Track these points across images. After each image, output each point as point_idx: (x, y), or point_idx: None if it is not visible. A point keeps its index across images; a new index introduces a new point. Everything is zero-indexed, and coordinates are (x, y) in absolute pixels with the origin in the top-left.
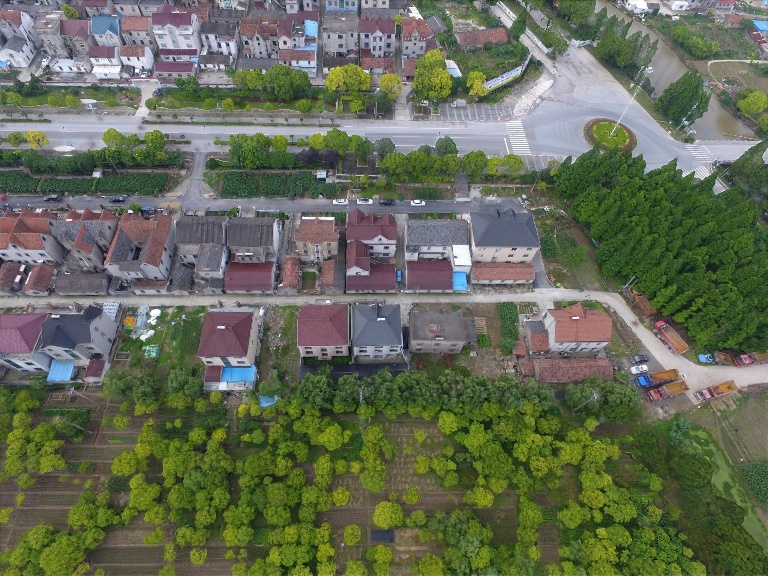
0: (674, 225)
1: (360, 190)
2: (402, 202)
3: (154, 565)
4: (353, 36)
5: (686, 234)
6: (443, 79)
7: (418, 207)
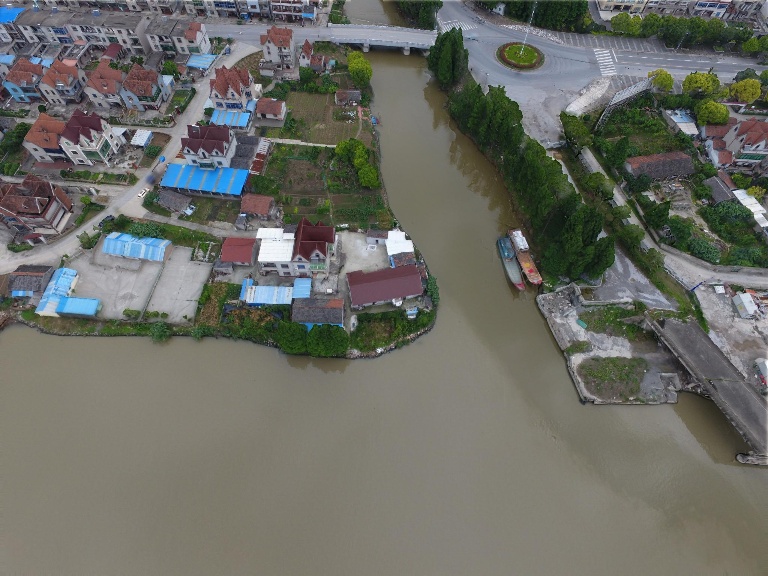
0: None
1: None
2: None
3: None
4: None
5: None
6: (701, 74)
7: None
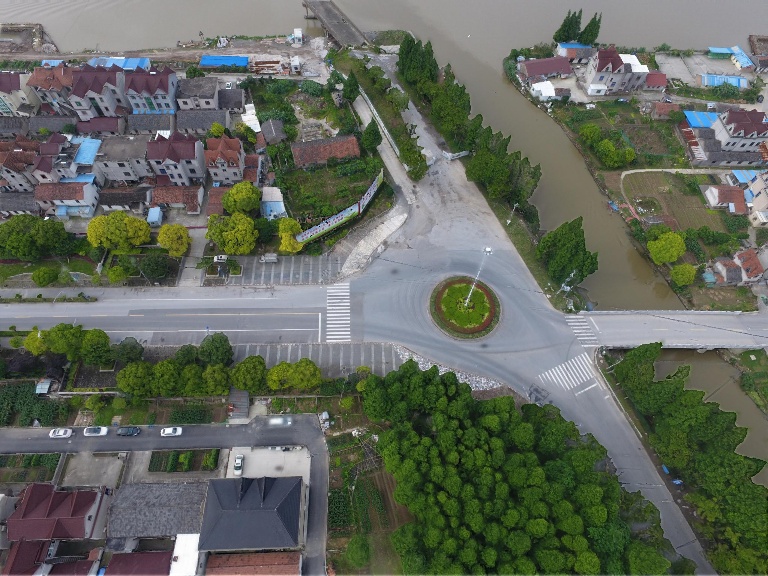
0: (496, 514)
1: (93, 412)
2: (151, 429)
3: None
4: (140, 163)
5: (512, 531)
6: (238, 233)
7: (171, 438)
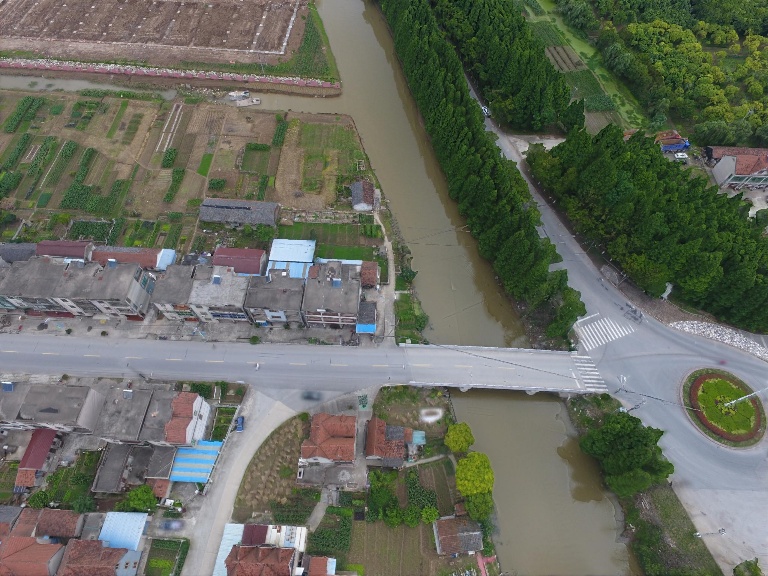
0: None
1: None
2: None
3: None
4: None
5: None
6: None
7: None
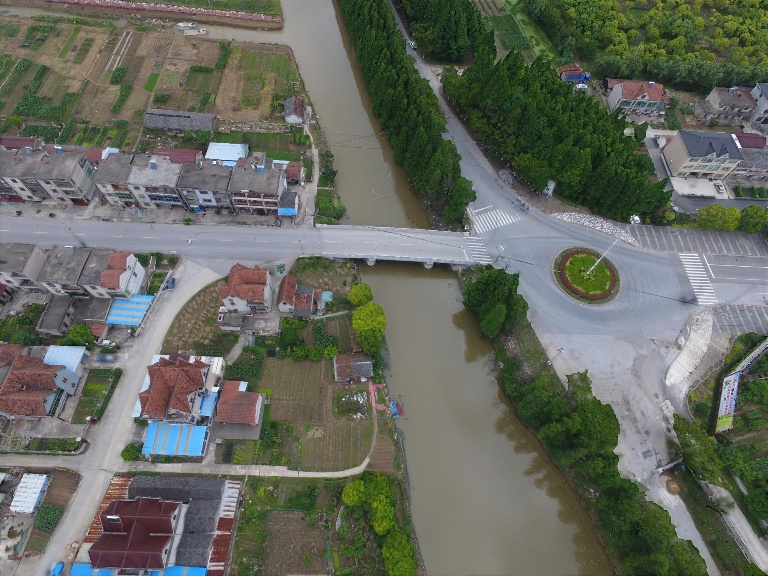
0: None
1: None
2: None
3: None
4: None
5: None
6: None
7: None
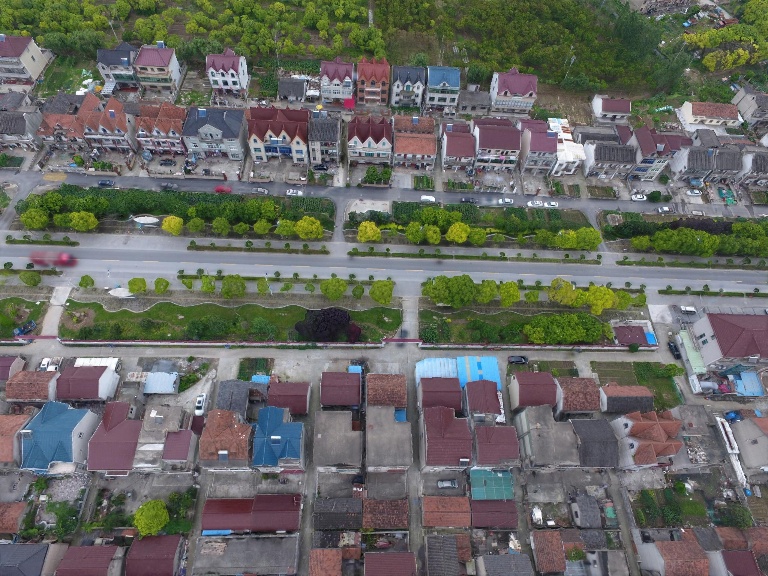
0: None
1: None
2: None
3: (99, 4)
4: None
5: None
6: None
7: None
